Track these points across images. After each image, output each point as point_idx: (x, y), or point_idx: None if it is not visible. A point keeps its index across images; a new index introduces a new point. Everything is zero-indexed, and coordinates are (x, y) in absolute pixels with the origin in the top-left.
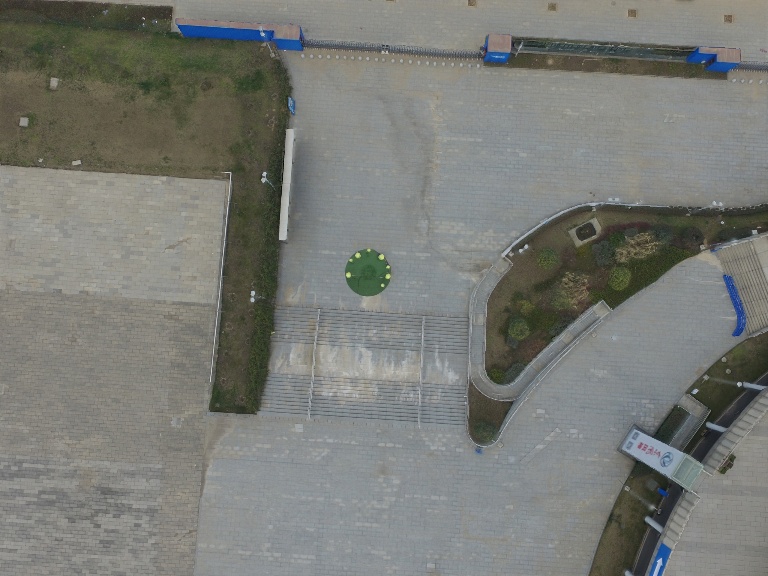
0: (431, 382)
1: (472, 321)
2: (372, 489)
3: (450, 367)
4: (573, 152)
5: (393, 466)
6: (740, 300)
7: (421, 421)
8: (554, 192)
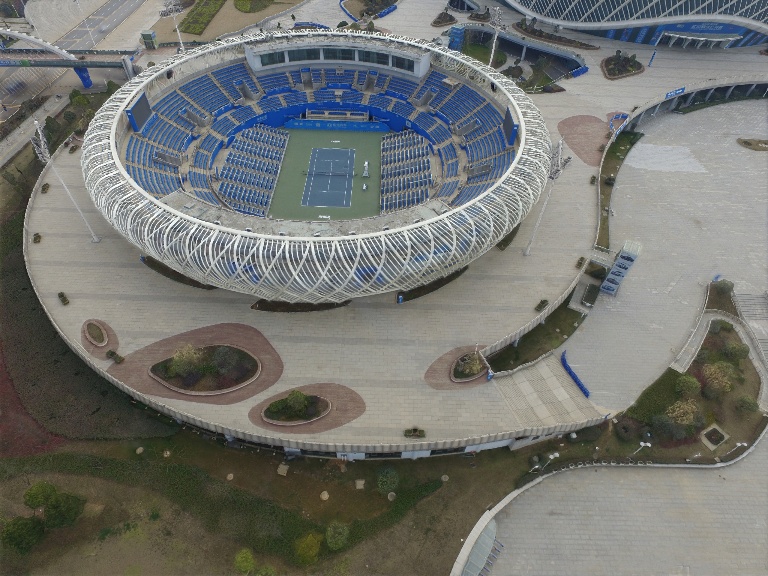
0: (767, 321)
1: (763, 363)
2: (767, 261)
3: (760, 331)
4: (765, 524)
5: (763, 272)
6: (575, 375)
7: (763, 296)
8: (759, 478)
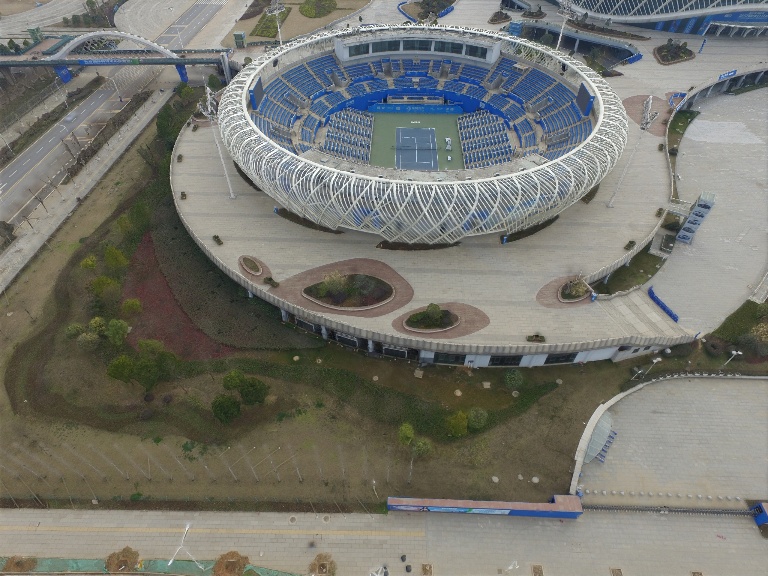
0: None
1: None
2: None
3: None
4: None
5: None
6: (664, 304)
7: None
8: None
